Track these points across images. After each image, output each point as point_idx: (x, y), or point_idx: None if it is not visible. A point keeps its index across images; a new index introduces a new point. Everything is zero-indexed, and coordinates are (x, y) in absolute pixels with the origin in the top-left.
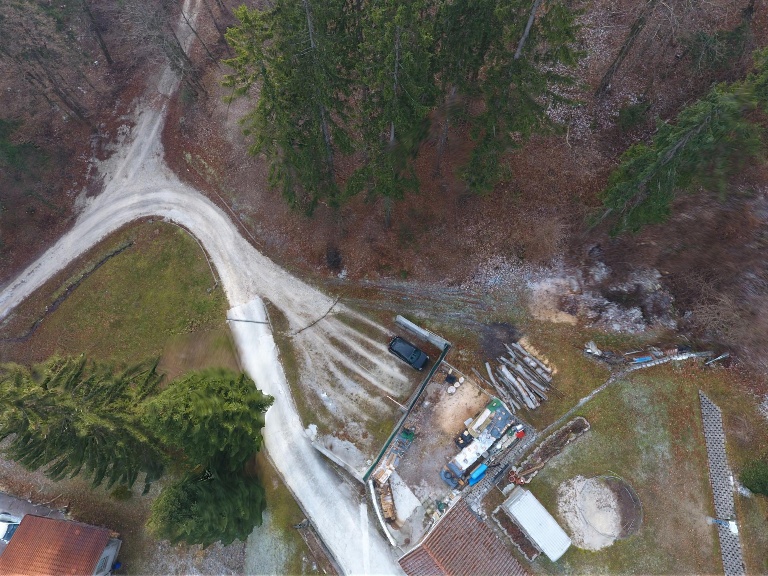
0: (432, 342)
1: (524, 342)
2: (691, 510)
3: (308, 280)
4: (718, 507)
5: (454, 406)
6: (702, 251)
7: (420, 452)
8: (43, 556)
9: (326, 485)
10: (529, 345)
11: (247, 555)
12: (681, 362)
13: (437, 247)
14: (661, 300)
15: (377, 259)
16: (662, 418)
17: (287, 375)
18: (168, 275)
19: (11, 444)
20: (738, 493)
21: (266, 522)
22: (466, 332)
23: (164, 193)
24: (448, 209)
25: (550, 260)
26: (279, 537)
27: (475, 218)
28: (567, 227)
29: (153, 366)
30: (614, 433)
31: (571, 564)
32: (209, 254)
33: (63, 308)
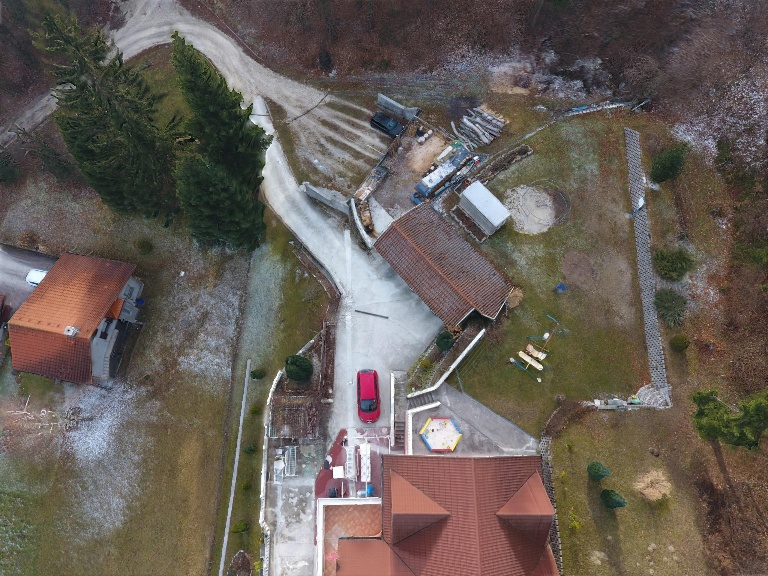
0: (407, 117)
1: (484, 107)
2: (613, 209)
3: (303, 81)
4: (634, 205)
5: (423, 153)
6: (635, 36)
7: (394, 185)
8: (80, 277)
9: (316, 221)
10: (488, 109)
11: (250, 278)
12: (611, 110)
13: (413, 41)
14: (600, 75)
15: (362, 57)
16: (593, 147)
17: (284, 150)
18: None
19: (49, 213)
20: (649, 188)
21: (266, 250)
22: (436, 104)
23: (178, 25)
24: (422, 7)
25: (508, 48)
26: (277, 260)
27: (445, 13)
28: (522, 18)
29: (173, 116)
30: (553, 157)
31: (513, 243)
32: (218, 68)
33: (91, 113)
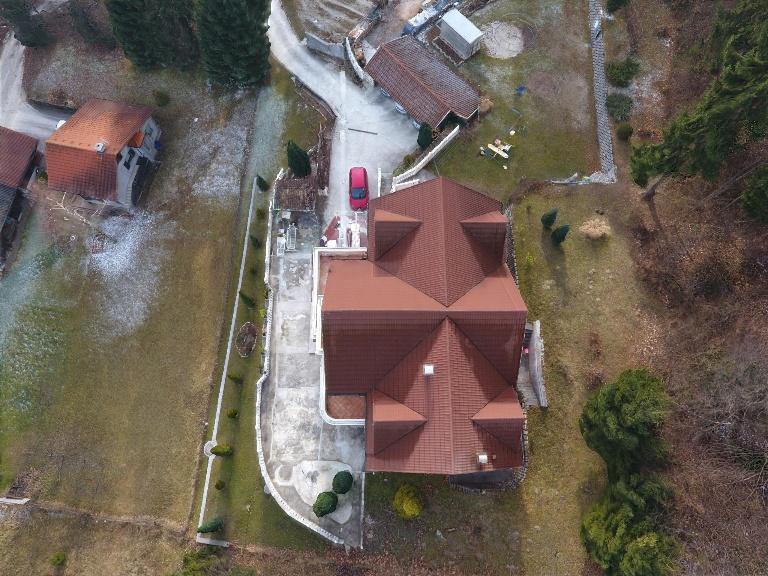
0: None
1: None
2: (574, 40)
3: None
4: (593, 36)
5: (411, 5)
6: None
7: (384, 30)
8: (106, 114)
9: (316, 66)
10: None
11: (256, 116)
12: None
13: None
14: None
15: None
16: None
17: (288, 15)
18: None
19: (76, 73)
20: (605, 18)
21: (271, 92)
22: None
23: None
24: None
25: None
26: (280, 98)
27: None
28: None
29: None
30: None
31: (486, 65)
32: None
33: None
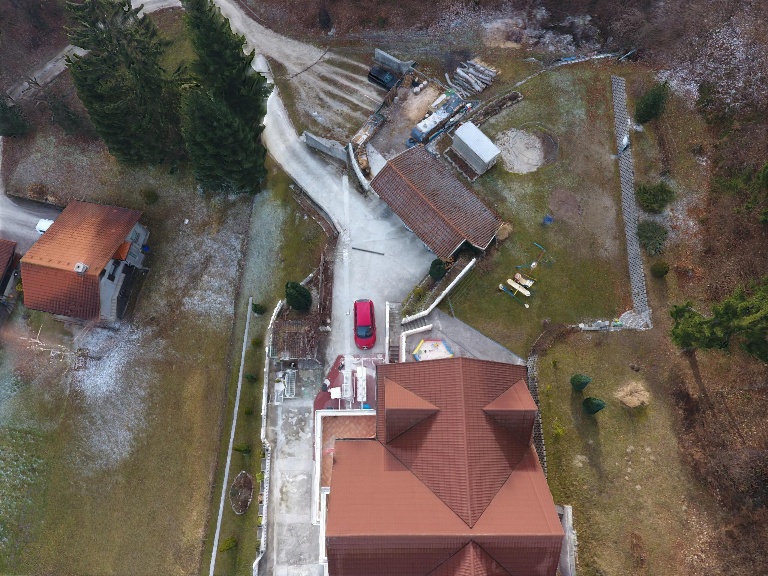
0: None
1: (477, 60)
2: (599, 150)
3: (303, 40)
4: (619, 146)
5: (419, 102)
6: None
7: (390, 132)
8: (89, 222)
9: (316, 168)
10: (481, 61)
11: (252, 222)
12: (599, 60)
13: None
14: (589, 30)
15: (360, 16)
16: (581, 94)
17: (285, 104)
18: (186, 45)
19: (58, 166)
20: (633, 129)
21: (267, 196)
22: (431, 58)
23: None
24: None
25: (501, 6)
26: (278, 205)
27: None
28: None
29: (178, 66)
30: (542, 103)
31: (503, 181)
32: None
33: None
